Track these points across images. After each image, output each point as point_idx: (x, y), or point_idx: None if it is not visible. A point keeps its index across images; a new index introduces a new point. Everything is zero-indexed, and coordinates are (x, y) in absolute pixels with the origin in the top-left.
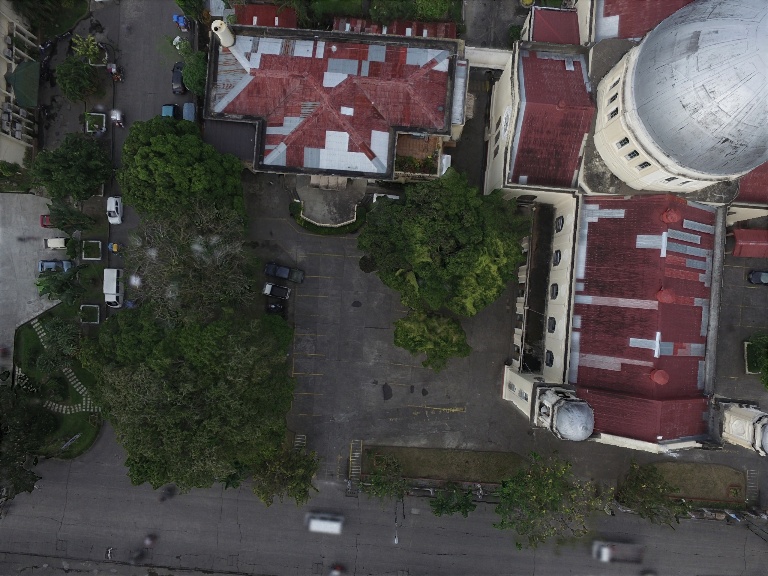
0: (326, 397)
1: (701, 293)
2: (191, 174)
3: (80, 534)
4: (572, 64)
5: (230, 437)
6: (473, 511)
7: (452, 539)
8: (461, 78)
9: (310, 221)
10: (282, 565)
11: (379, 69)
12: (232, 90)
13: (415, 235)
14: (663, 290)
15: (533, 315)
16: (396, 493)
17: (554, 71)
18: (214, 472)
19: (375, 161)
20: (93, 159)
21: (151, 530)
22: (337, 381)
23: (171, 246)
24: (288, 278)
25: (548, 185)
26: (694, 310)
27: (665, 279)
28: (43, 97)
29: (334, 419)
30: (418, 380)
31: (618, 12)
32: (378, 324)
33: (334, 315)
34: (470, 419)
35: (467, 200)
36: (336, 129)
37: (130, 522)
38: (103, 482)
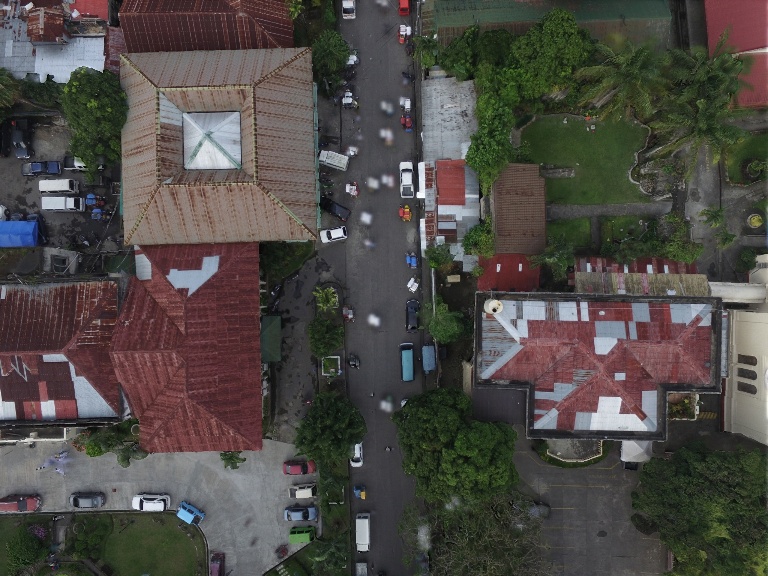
0: None
1: None
2: (494, 472)
3: None
4: None
5: None
6: None
7: None
8: (723, 330)
9: (555, 457)
10: None
11: (647, 331)
12: (500, 358)
13: (711, 513)
14: None
15: None
16: None
17: None
18: None
19: (646, 421)
20: (356, 426)
21: None
22: None
23: (488, 555)
24: None
25: None
26: None
27: None
28: None
29: None
30: None
31: None
32: (625, 553)
33: (580, 546)
34: None
35: (765, 479)
36: (609, 395)
37: None
38: None
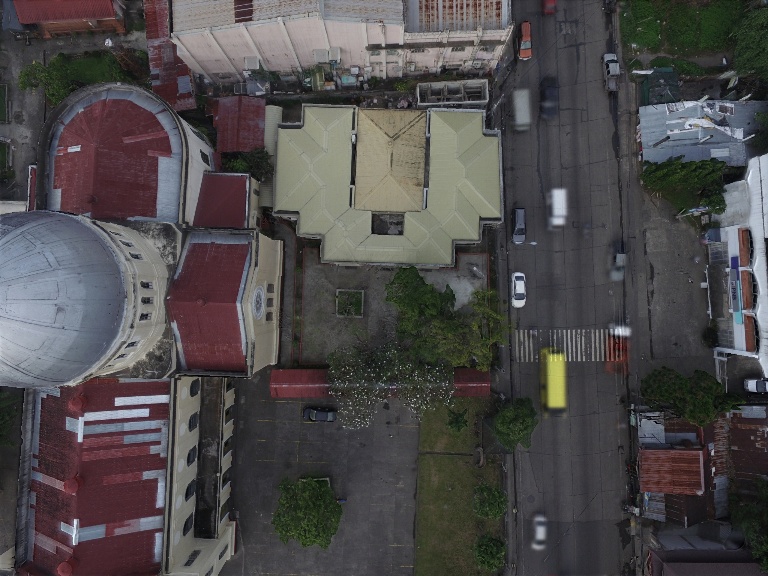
0: None
1: (155, 465)
2: None
3: None
4: None
5: None
6: None
7: None
8: None
9: None
10: None
11: None
12: None
13: None
14: (65, 481)
15: None
16: None
17: None
18: None
19: None
20: None
21: None
22: None
23: None
24: None
25: None
26: (143, 484)
27: (83, 464)
28: None
29: None
30: None
31: (61, 185)
32: None
33: None
34: None
35: None
36: None
37: None
38: None
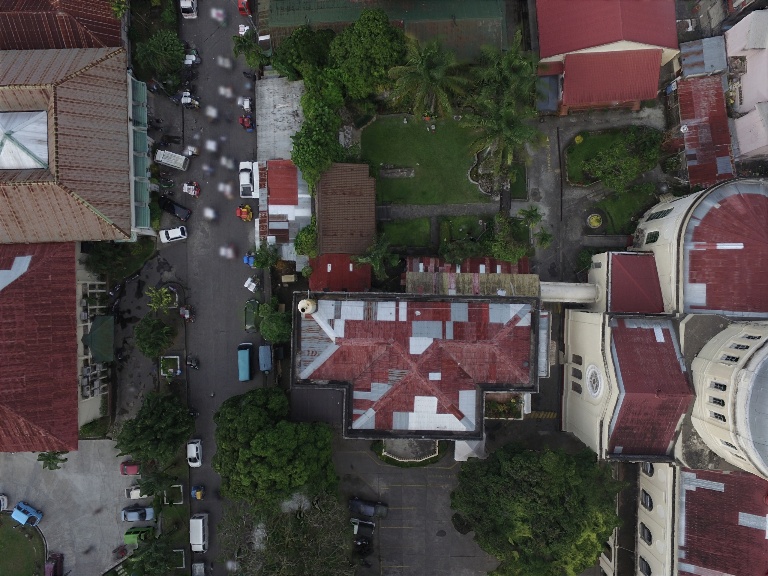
0: None
1: None
2: (292, 472)
3: None
4: (662, 334)
5: None
6: None
7: None
8: (543, 329)
9: (392, 457)
10: None
11: (464, 330)
12: (318, 358)
13: (515, 512)
14: None
15: (624, 552)
16: None
17: (645, 345)
18: None
19: (464, 421)
20: (178, 426)
21: None
22: None
23: (279, 555)
24: (373, 515)
25: (643, 453)
26: None
27: None
28: (115, 342)
29: None
30: None
31: (705, 281)
32: (464, 552)
33: (419, 546)
34: None
35: (566, 478)
36: (425, 394)
37: None
38: None
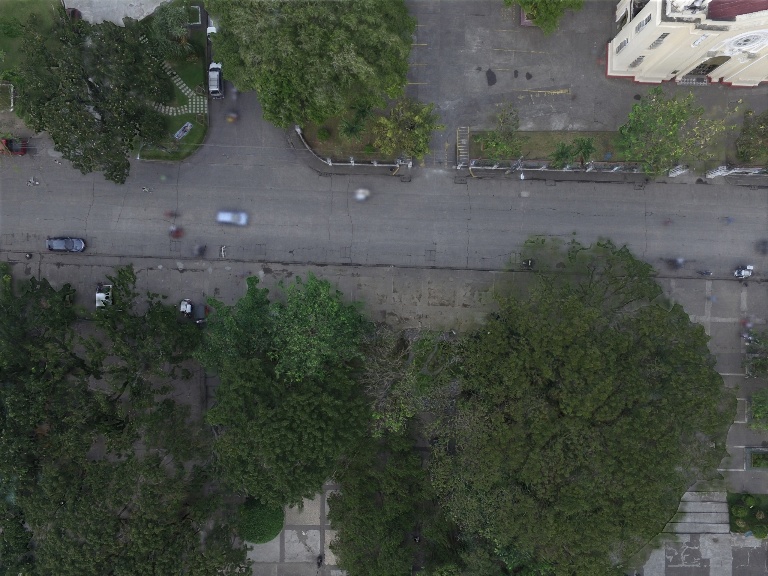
0: (430, 86)
1: None
2: None
3: (193, 234)
4: None
5: (365, 39)
6: (582, 191)
7: (563, 219)
8: None
9: None
10: (395, 254)
11: None
12: None
13: None
14: None
15: None
16: (512, 153)
17: None
18: (353, 68)
19: None
20: None
21: (263, 226)
22: (440, 69)
23: None
24: None
25: None
26: None
27: None
28: None
29: (439, 107)
30: (521, 64)
31: None
32: (479, 11)
33: (434, 4)
34: (575, 100)
35: None
36: None
37: (242, 219)
38: (213, 182)
